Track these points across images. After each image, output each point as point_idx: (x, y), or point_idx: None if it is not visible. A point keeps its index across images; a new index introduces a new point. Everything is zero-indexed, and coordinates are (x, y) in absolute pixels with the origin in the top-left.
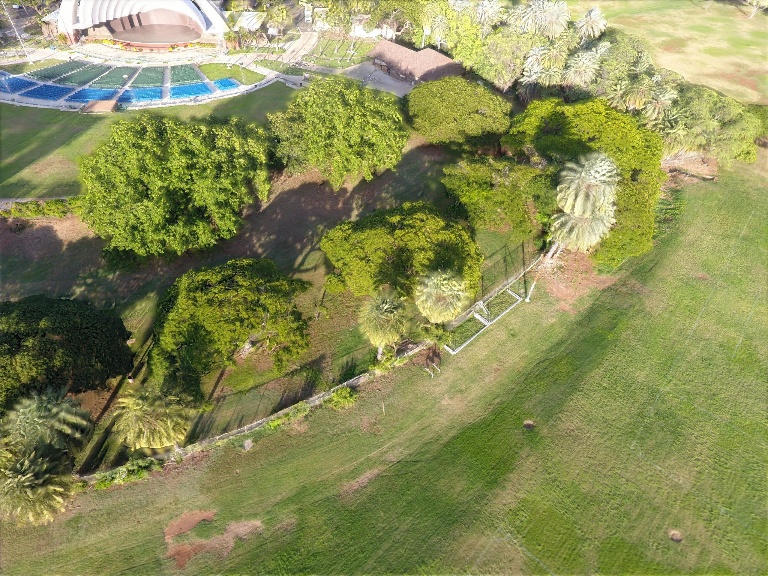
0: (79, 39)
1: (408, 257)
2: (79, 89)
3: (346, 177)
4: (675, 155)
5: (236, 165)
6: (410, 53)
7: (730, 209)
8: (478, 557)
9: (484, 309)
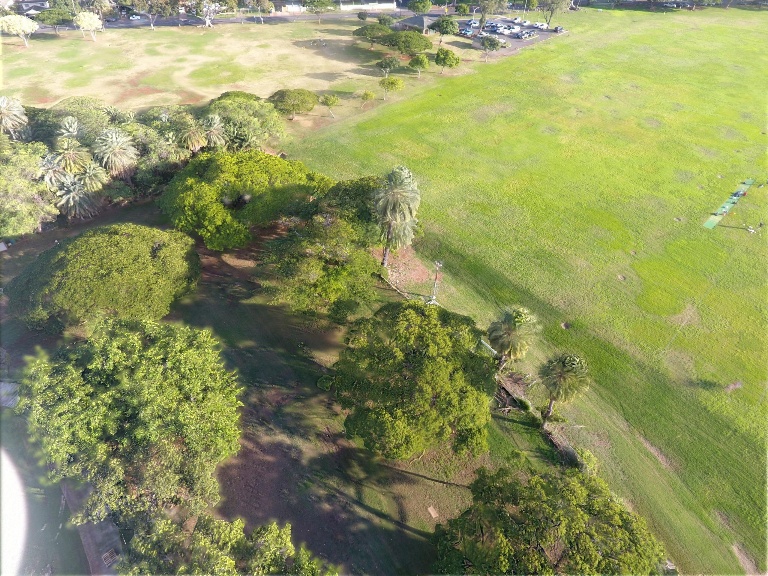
0: None
1: (460, 350)
2: None
3: None
4: None
5: (265, 573)
6: None
7: (327, 161)
8: (685, 375)
9: None
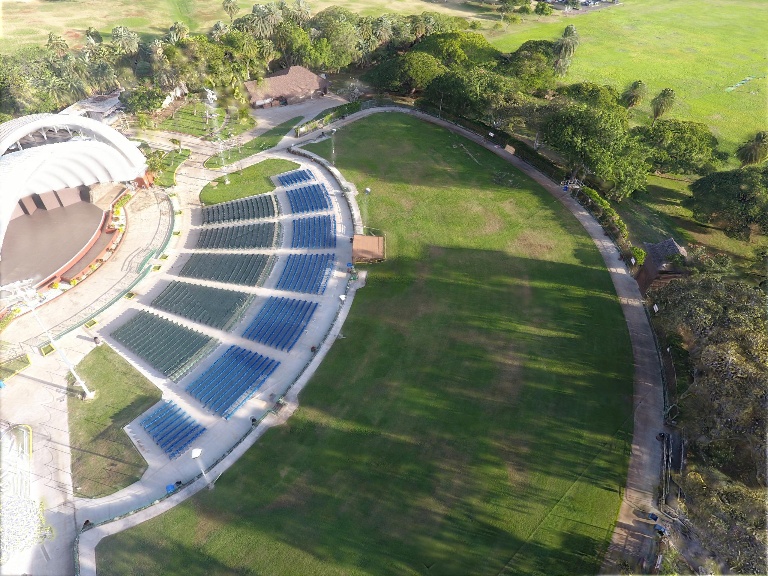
0: None
1: None
2: (267, 295)
3: None
4: None
5: None
6: (285, 78)
7: None
8: None
9: None
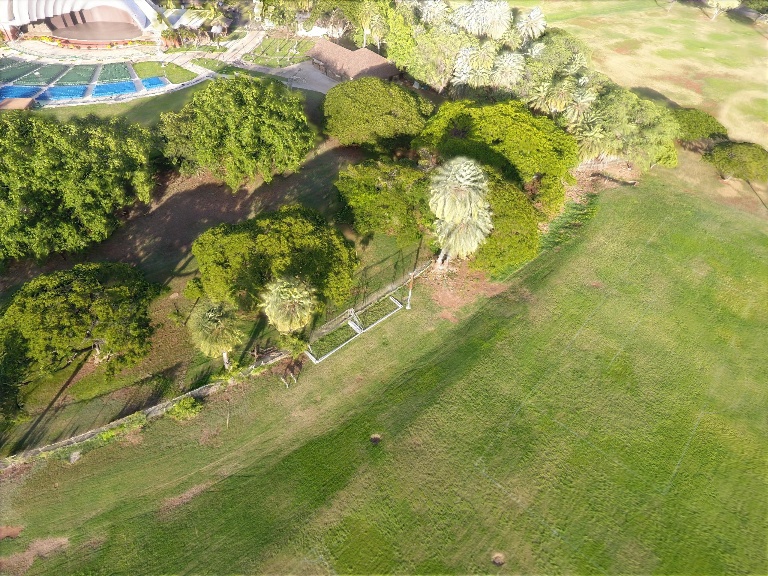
0: (18, 36)
1: (267, 263)
2: (2, 86)
3: (248, 178)
4: (597, 159)
5: (110, 166)
6: (346, 53)
7: (643, 215)
8: None
9: (355, 317)
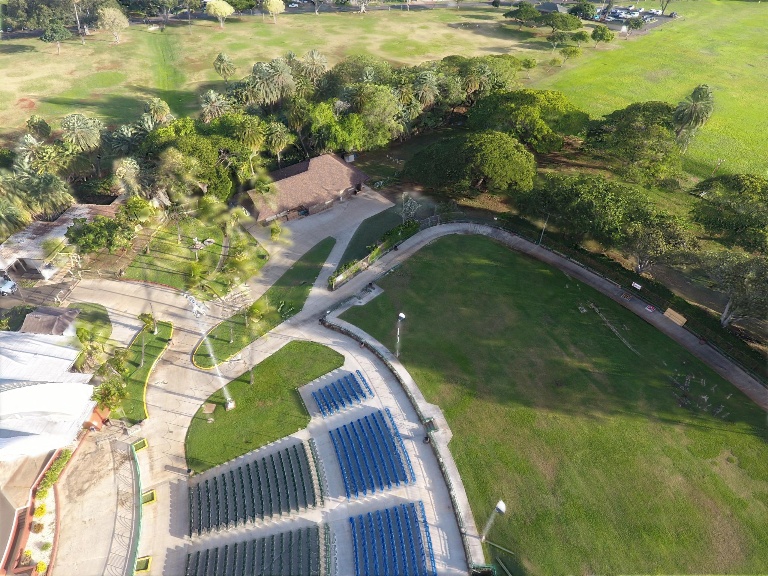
0: None
1: None
2: None
3: None
4: None
5: None
6: (304, 177)
7: None
8: None
9: None
